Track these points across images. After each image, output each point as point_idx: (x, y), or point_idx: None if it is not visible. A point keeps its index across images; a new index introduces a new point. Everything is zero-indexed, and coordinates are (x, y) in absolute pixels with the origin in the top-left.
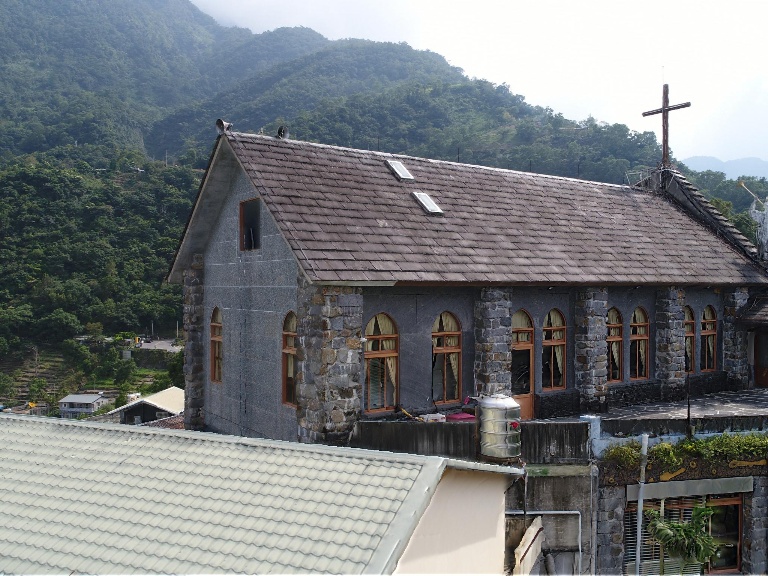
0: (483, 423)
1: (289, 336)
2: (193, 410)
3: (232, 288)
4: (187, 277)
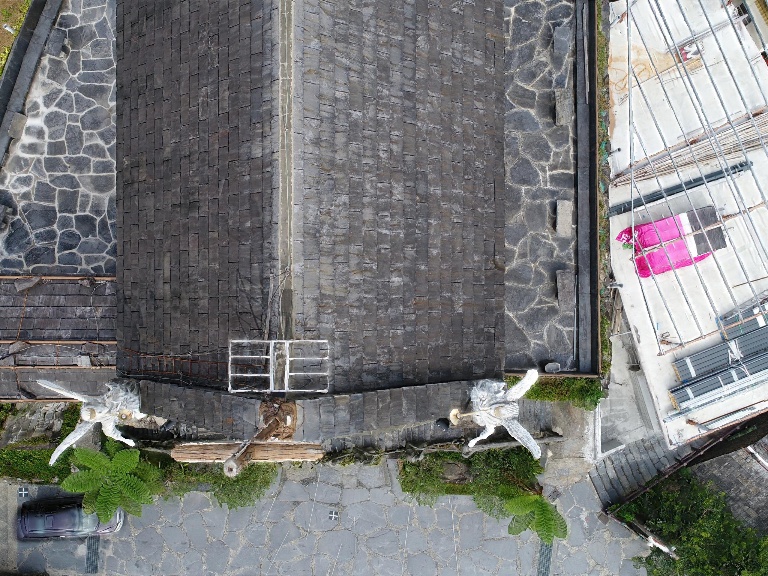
0: None
1: None
2: None
3: None
4: None
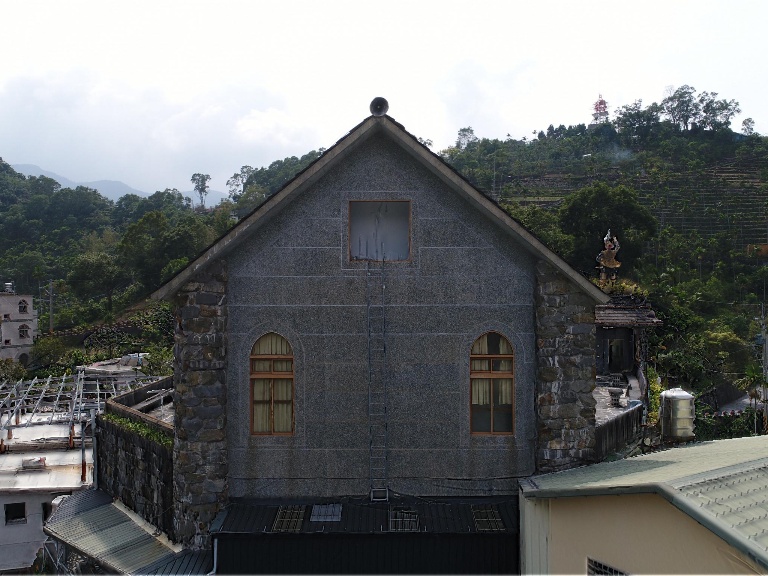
0: (680, 412)
1: (477, 359)
2: (224, 481)
3: (329, 307)
4: (204, 292)
